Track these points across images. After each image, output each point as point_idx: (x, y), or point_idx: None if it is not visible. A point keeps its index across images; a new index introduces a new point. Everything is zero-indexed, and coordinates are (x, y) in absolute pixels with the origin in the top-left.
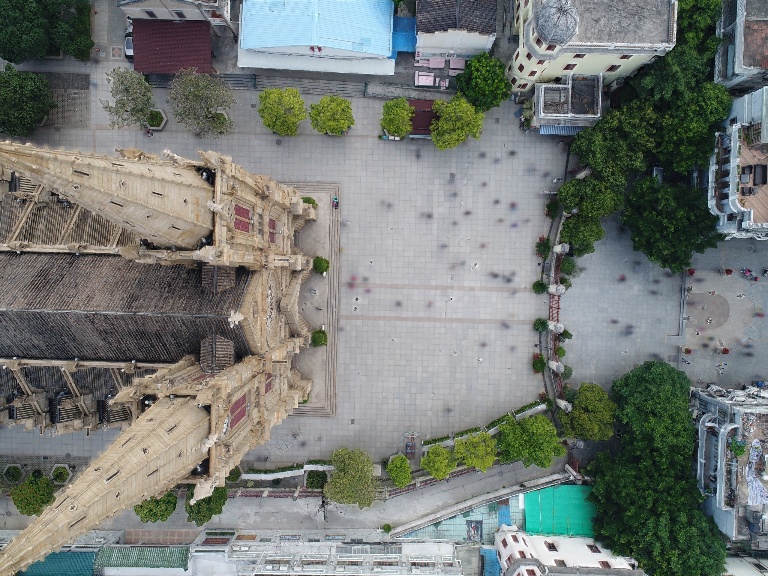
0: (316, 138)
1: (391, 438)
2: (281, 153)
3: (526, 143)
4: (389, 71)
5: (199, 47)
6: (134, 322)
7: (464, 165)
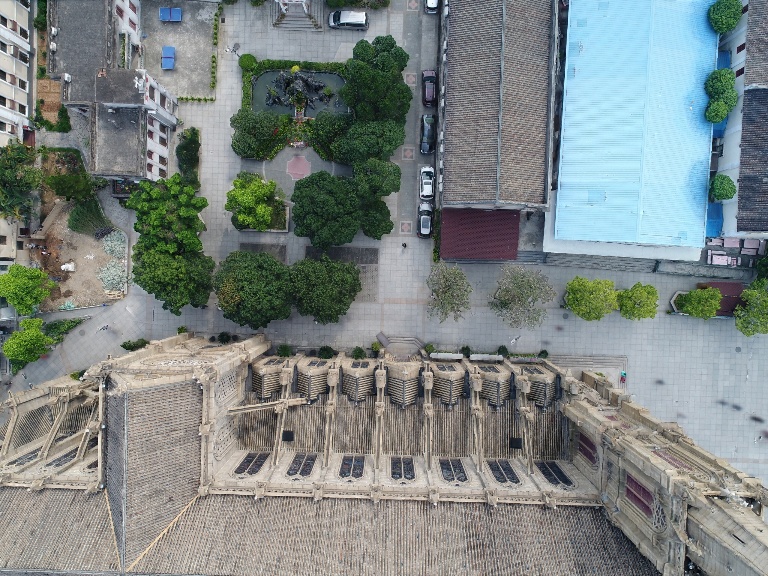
0: None
1: None
2: (568, 327)
3: None
4: (695, 257)
5: (507, 234)
6: None
7: (750, 339)
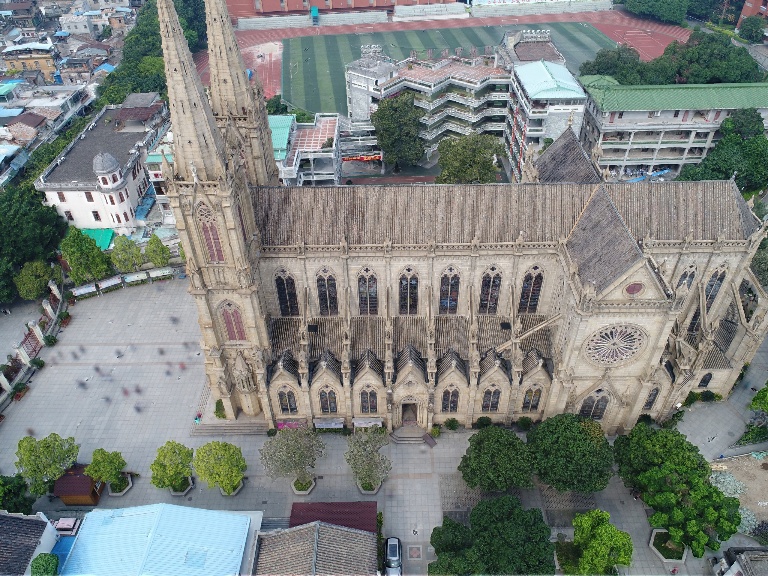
0: None
1: None
2: None
3: None
4: None
5: None
6: None
7: None
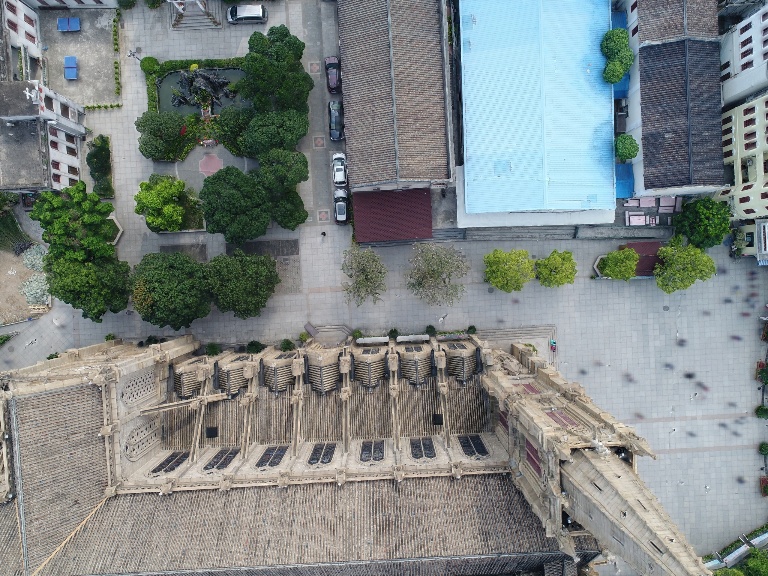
0: (528, 283)
1: (624, 572)
2: (494, 301)
3: (737, 270)
4: (609, 220)
5: (420, 213)
6: (491, 560)
7: (677, 297)
